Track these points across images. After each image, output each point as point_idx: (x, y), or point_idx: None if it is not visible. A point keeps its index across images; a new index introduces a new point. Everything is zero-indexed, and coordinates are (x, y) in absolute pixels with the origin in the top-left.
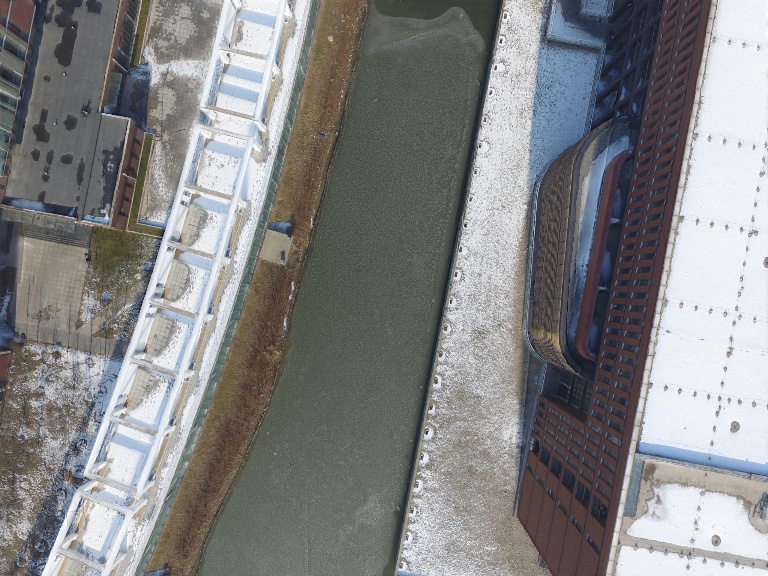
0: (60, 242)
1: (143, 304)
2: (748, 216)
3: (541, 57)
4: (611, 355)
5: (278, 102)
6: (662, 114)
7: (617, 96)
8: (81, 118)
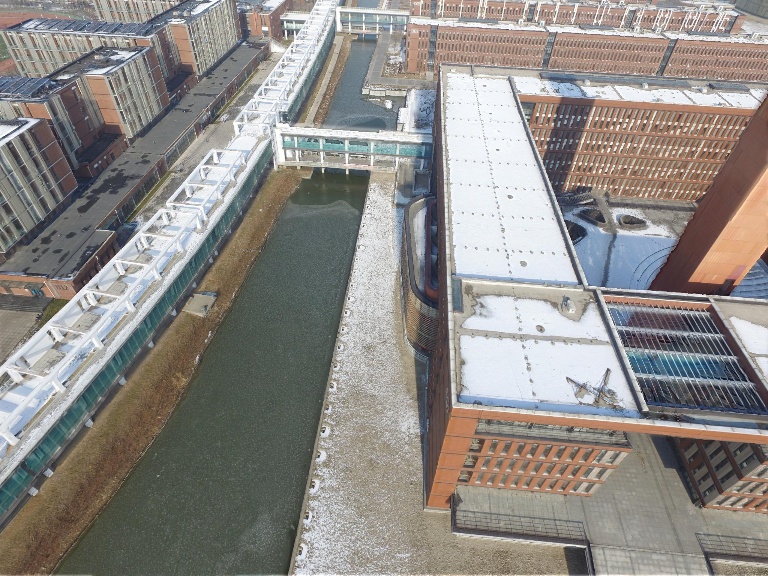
0: (20, 310)
1: (81, 290)
2: (490, 182)
3: (393, 211)
4: None
5: (218, 210)
6: (439, 171)
7: None
8: (80, 233)
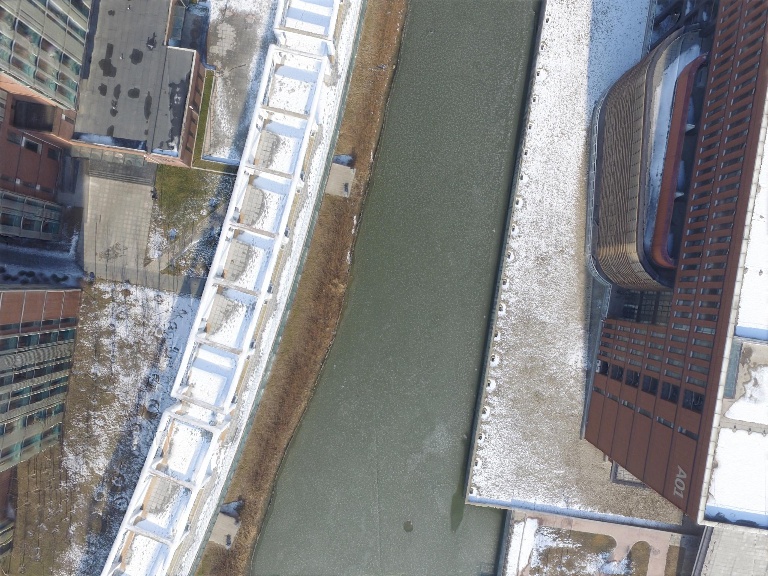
0: (125, 181)
1: (224, 225)
2: None
3: None
4: (695, 254)
5: (346, 25)
6: (743, 11)
7: (681, 11)
8: (146, 52)
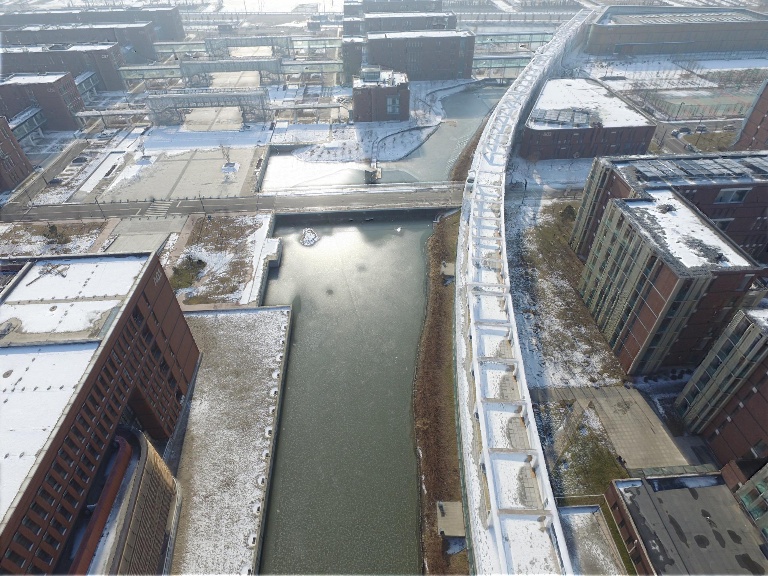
0: None
1: None
2: None
3: None
4: (101, 429)
5: None
6: None
7: None
8: None
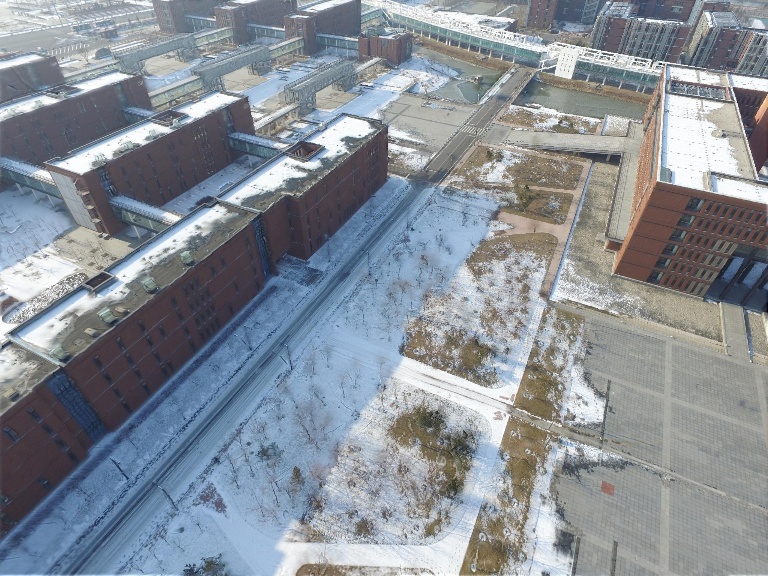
0: None
1: None
2: None
3: None
4: None
5: None
6: None
7: None
8: None
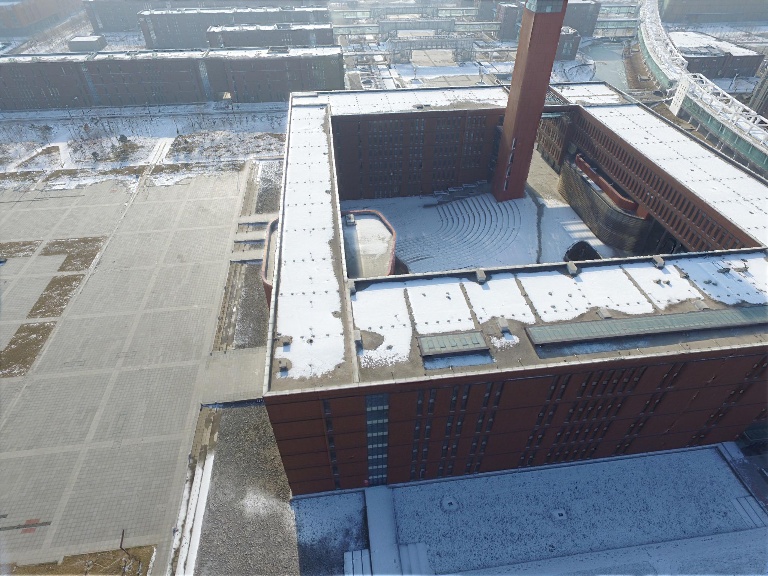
0: None
1: None
2: None
3: None
4: None
5: None
6: None
7: None
8: None
